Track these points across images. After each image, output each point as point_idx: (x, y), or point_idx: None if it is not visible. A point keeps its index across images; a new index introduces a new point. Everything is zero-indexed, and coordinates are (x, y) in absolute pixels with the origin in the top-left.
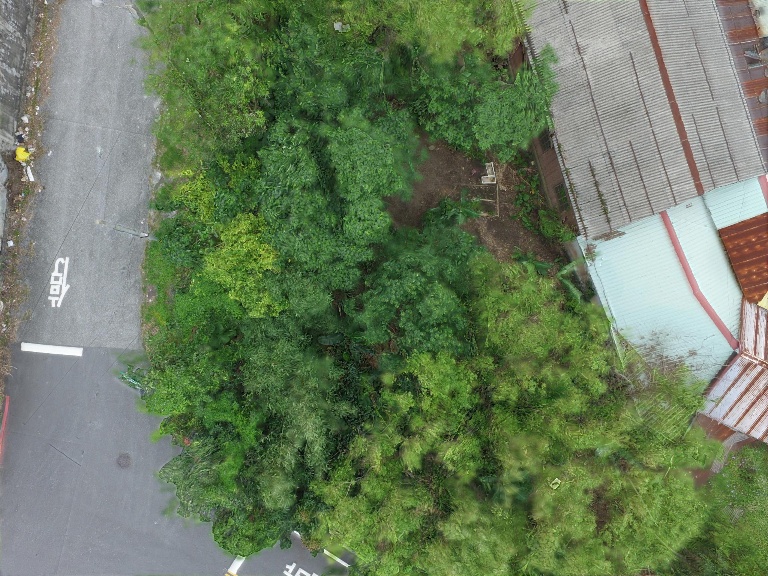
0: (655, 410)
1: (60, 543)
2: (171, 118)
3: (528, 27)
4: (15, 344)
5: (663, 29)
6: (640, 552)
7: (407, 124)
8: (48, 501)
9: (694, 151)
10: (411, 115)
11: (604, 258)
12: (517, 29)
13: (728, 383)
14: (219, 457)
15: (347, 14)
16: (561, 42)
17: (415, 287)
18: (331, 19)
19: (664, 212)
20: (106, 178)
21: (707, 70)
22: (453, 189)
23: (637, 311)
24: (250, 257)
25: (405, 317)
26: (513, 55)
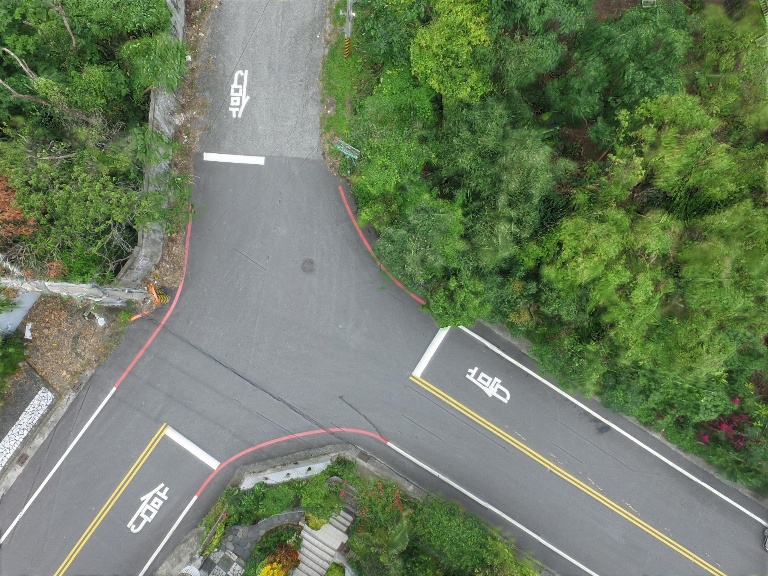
0: None
1: (249, 344)
2: None
3: None
4: (197, 154)
5: None
6: None
7: None
8: (236, 304)
9: None
10: None
11: None
12: None
13: None
14: None
15: None
16: None
17: (648, 32)
18: None
19: None
20: None
21: None
22: (614, 13)
23: None
24: (459, 33)
25: (634, 68)
26: None
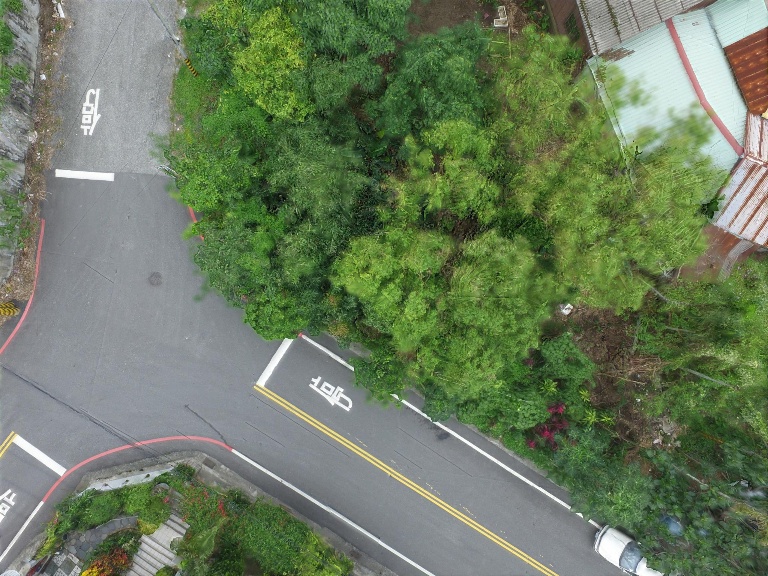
0: (664, 225)
1: (96, 355)
2: None
3: None
4: (49, 171)
5: None
6: (651, 341)
7: None
8: (84, 316)
9: None
10: None
11: (614, 78)
12: None
13: (734, 188)
14: None
15: None
16: None
17: (437, 60)
18: None
19: (671, 25)
20: (134, 14)
21: None
22: (466, 32)
23: (646, 127)
24: (277, 57)
25: (427, 93)
26: None
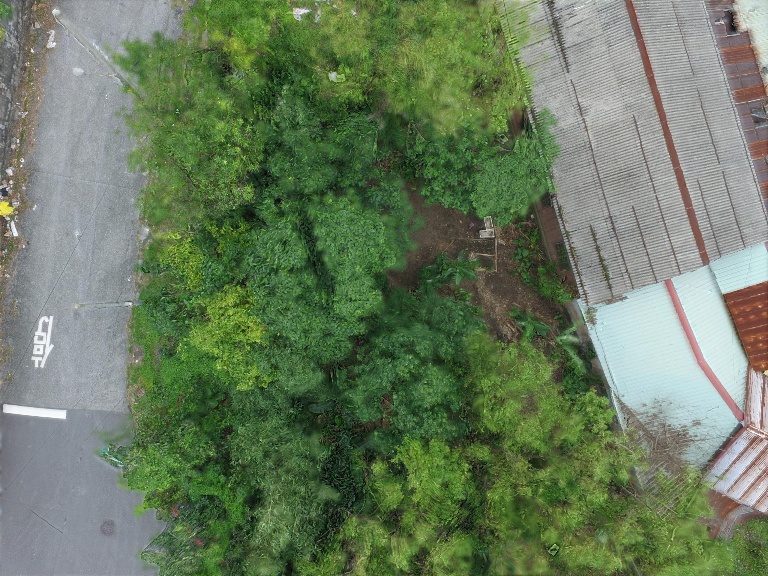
0: (657, 479)
1: None
2: (160, 171)
3: (528, 85)
4: None
5: (668, 91)
6: None
7: (403, 177)
8: (29, 570)
9: (699, 219)
10: (407, 168)
11: (605, 322)
12: (517, 84)
13: (733, 456)
14: (204, 539)
15: (342, 64)
16: (562, 101)
17: (408, 370)
18: (325, 69)
19: None
20: (92, 234)
21: (713, 132)
22: (450, 243)
23: (639, 378)
24: (238, 328)
25: (398, 399)
26: (513, 107)
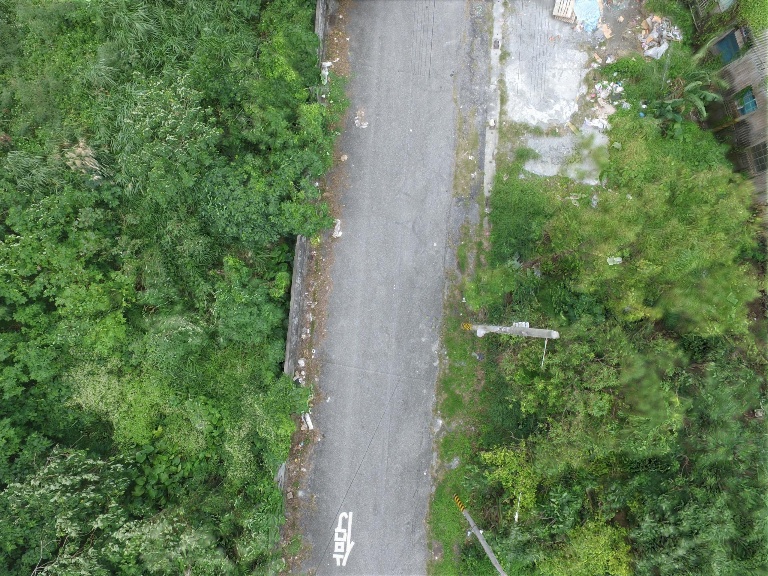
0: None
1: None
2: (450, 362)
3: None
4: None
5: None
6: None
7: (680, 357)
8: None
9: None
10: (686, 350)
11: None
12: None
13: None
14: None
15: (623, 250)
16: None
17: None
18: (606, 255)
19: None
20: (387, 427)
21: None
22: None
23: None
24: None
25: None
26: None
